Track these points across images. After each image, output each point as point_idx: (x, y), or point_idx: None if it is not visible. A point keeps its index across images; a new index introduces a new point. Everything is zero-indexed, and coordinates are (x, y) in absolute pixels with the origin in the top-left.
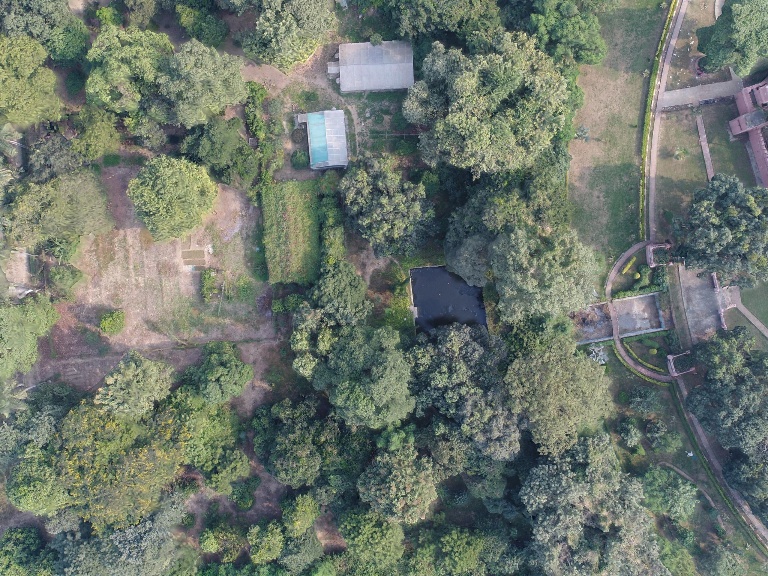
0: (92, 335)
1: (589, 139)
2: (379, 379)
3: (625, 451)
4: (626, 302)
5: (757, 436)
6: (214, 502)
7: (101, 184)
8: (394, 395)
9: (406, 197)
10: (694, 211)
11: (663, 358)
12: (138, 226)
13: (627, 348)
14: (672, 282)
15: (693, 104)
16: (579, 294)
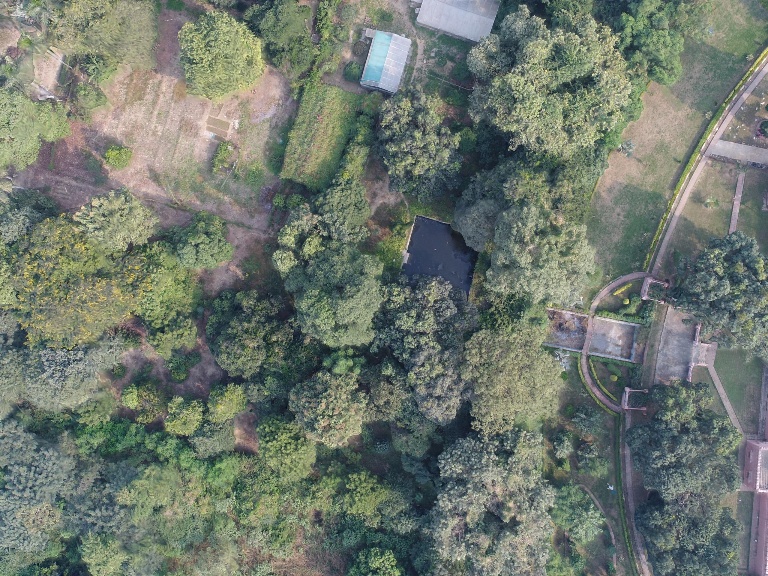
0: (94, 162)
1: (631, 155)
2: (349, 298)
3: (552, 461)
4: (606, 323)
5: (680, 486)
6: (150, 363)
7: (157, 20)
8: (357, 319)
9: (439, 141)
10: (703, 255)
11: (621, 388)
12: (177, 76)
13: (591, 366)
14: (657, 320)
15: (741, 161)
16: (567, 286)
